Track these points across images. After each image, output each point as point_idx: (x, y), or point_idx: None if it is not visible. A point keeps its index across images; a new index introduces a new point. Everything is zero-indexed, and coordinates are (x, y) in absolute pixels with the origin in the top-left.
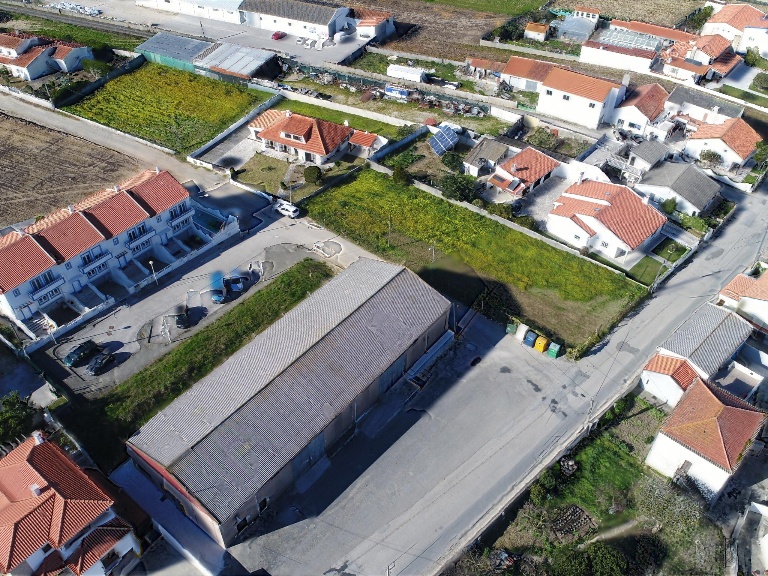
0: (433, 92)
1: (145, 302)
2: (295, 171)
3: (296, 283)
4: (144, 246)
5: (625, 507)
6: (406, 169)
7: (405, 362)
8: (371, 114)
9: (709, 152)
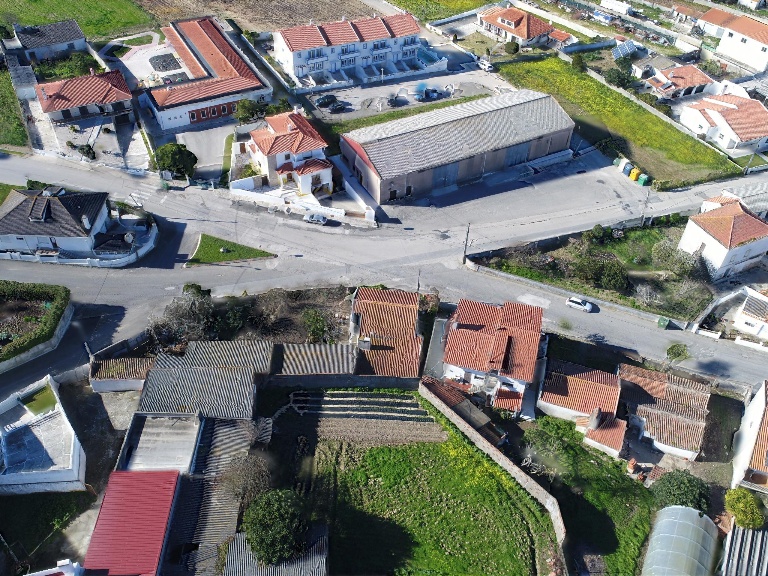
0: None
1: (372, 89)
2: (500, 47)
3: None
4: (381, 59)
5: (647, 264)
6: (586, 63)
7: (529, 151)
8: (574, 25)
9: None
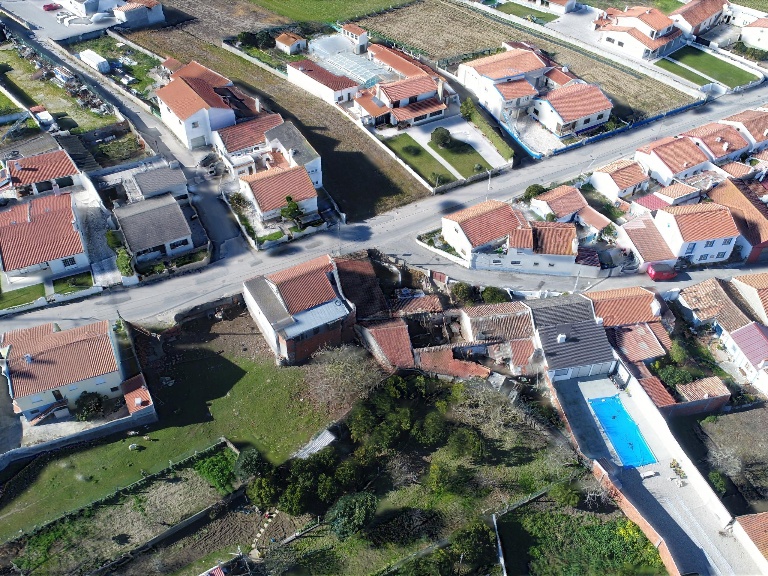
0: (104, 83)
1: None
2: None
3: None
4: None
5: None
6: None
7: None
8: (4, 91)
9: (235, 195)
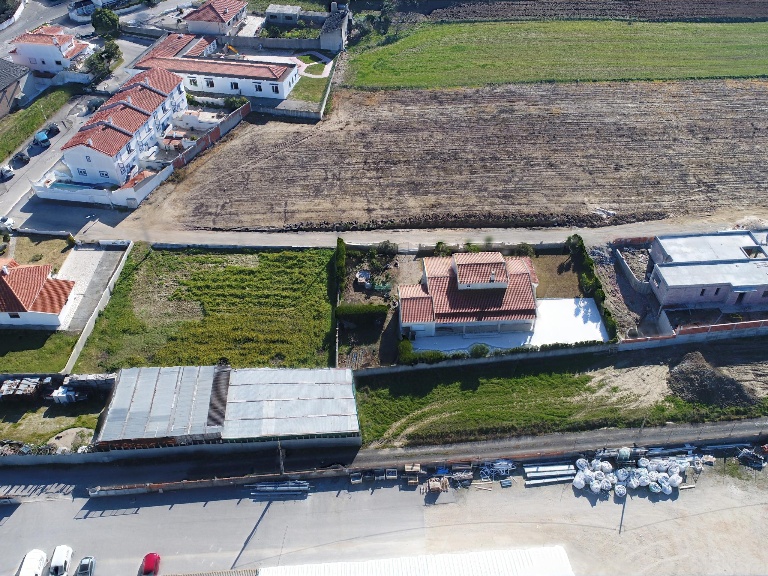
0: None
1: None
2: None
3: None
4: None
5: None
6: None
7: None
8: None
9: None
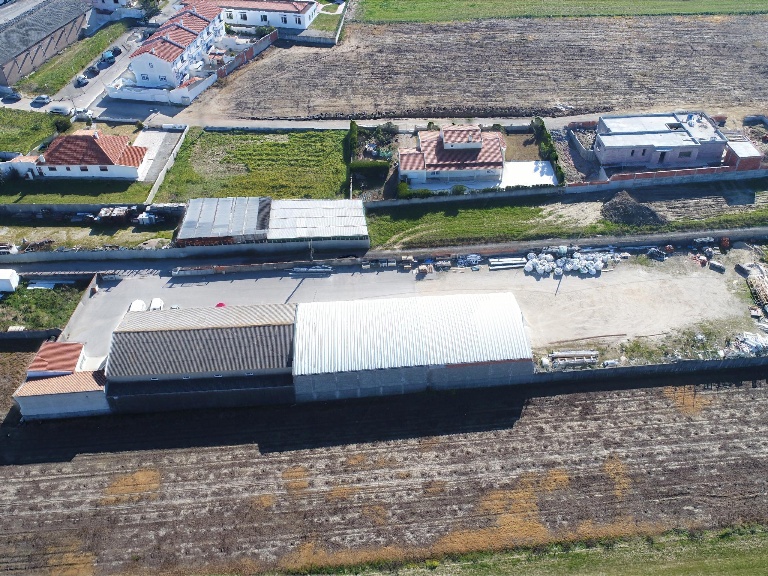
0: None
1: None
2: None
3: (53, 78)
4: None
5: None
6: None
7: None
8: (28, 206)
9: None
